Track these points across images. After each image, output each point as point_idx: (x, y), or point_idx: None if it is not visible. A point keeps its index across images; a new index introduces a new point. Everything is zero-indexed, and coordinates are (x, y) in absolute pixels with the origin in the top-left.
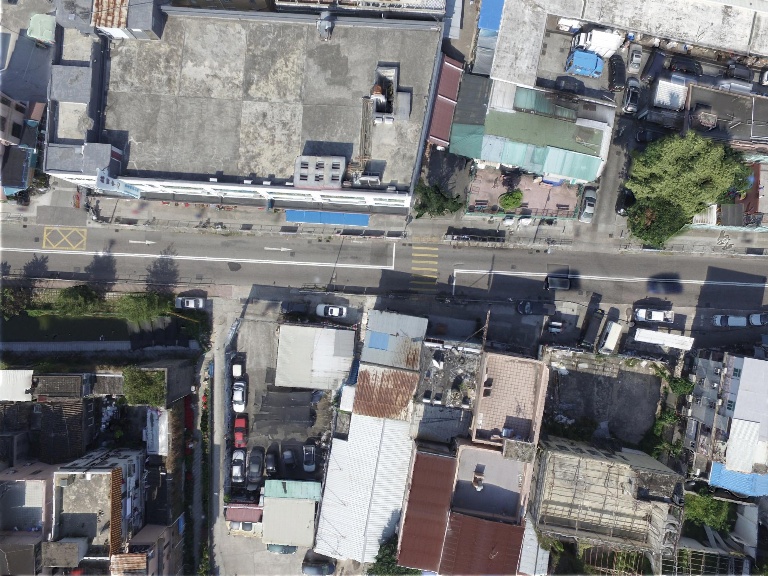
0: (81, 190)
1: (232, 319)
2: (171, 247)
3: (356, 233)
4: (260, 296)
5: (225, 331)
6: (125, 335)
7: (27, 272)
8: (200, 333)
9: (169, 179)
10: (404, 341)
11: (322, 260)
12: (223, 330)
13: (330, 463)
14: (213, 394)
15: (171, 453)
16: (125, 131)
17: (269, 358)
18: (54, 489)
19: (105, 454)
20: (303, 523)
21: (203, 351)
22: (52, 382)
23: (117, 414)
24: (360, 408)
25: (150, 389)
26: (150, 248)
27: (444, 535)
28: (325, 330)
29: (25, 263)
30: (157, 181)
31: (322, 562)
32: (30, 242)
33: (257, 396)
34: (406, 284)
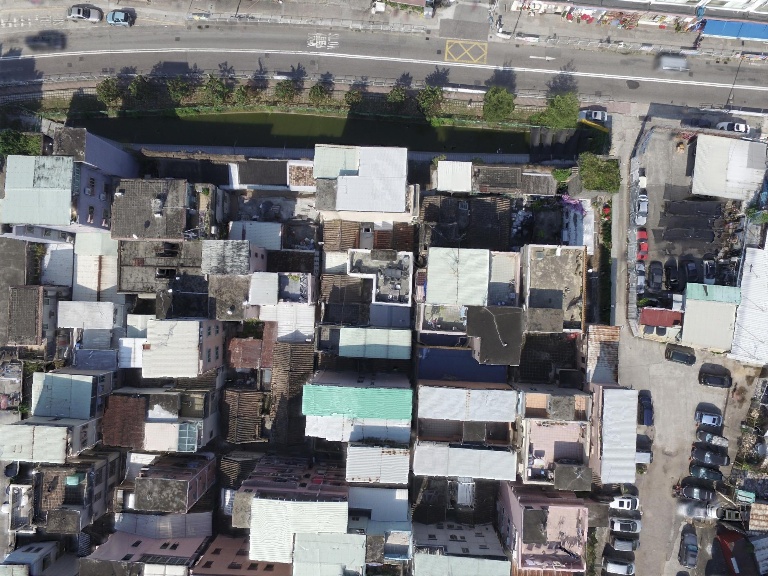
0: None
1: (631, 135)
2: (571, 64)
3: None
4: (658, 114)
5: (624, 147)
6: (522, 149)
7: (428, 84)
8: (604, 146)
9: None
10: None
11: (720, 81)
12: (622, 146)
13: (744, 271)
14: None
15: (598, 251)
16: None
17: (668, 174)
18: (529, 261)
19: None
20: (724, 326)
21: None
22: (493, 173)
23: (534, 217)
24: None
25: (604, 176)
26: (550, 64)
27: None
28: (740, 141)
29: (427, 75)
30: None
31: (720, 375)
32: (432, 54)
33: (656, 211)
34: None
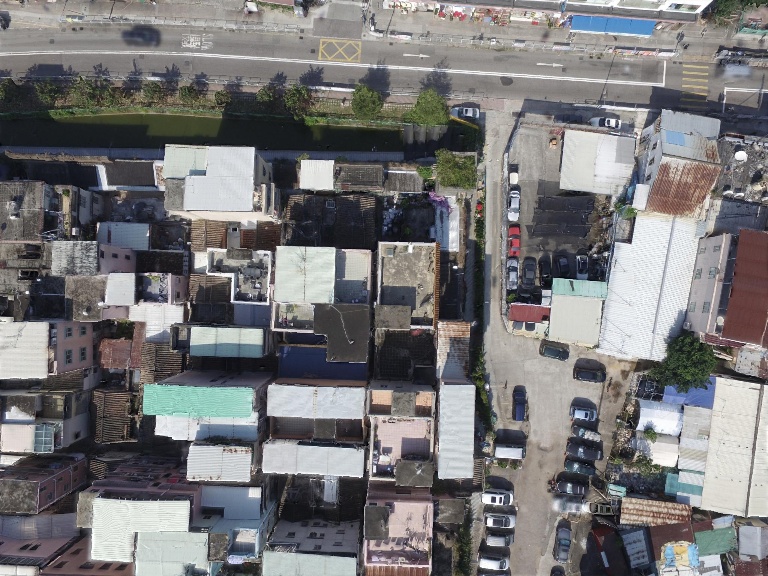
0: None
1: (505, 132)
2: (444, 61)
3: (629, 49)
4: (532, 110)
5: (497, 143)
6: (397, 147)
7: (303, 83)
8: (476, 143)
9: None
10: (699, 139)
11: (593, 76)
12: (495, 142)
13: (612, 266)
14: (485, 205)
15: (463, 248)
16: None
17: (541, 170)
18: (380, 258)
19: None
20: (590, 321)
21: (478, 161)
22: (354, 171)
23: (403, 214)
24: (655, 204)
25: (461, 173)
26: (424, 61)
27: (767, 309)
28: (608, 136)
29: (301, 74)
30: None
31: (594, 370)
32: (306, 53)
33: (529, 207)
34: (676, 101)
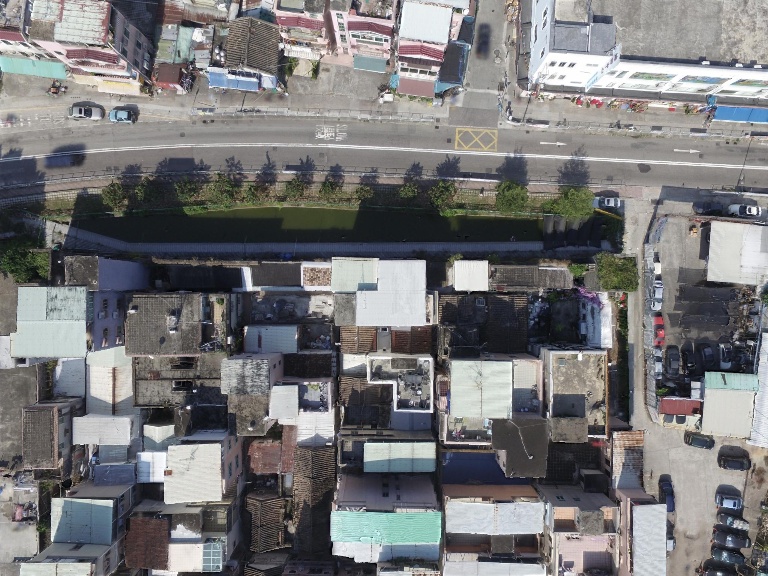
0: (532, 82)
1: (644, 220)
2: (582, 149)
3: None
4: (670, 197)
5: (637, 231)
6: (536, 236)
7: (440, 173)
8: (617, 232)
9: (664, 62)
10: None
11: (730, 162)
12: (635, 230)
13: (761, 357)
14: None
15: (617, 344)
16: (609, 16)
17: (681, 258)
18: (551, 368)
19: (556, 344)
20: (742, 414)
21: (620, 250)
22: (510, 272)
23: (551, 309)
24: None
25: (622, 275)
26: (561, 149)
27: None
28: (753, 226)
29: (438, 164)
30: (652, 64)
31: (739, 457)
32: (442, 143)
33: (670, 295)
34: None
